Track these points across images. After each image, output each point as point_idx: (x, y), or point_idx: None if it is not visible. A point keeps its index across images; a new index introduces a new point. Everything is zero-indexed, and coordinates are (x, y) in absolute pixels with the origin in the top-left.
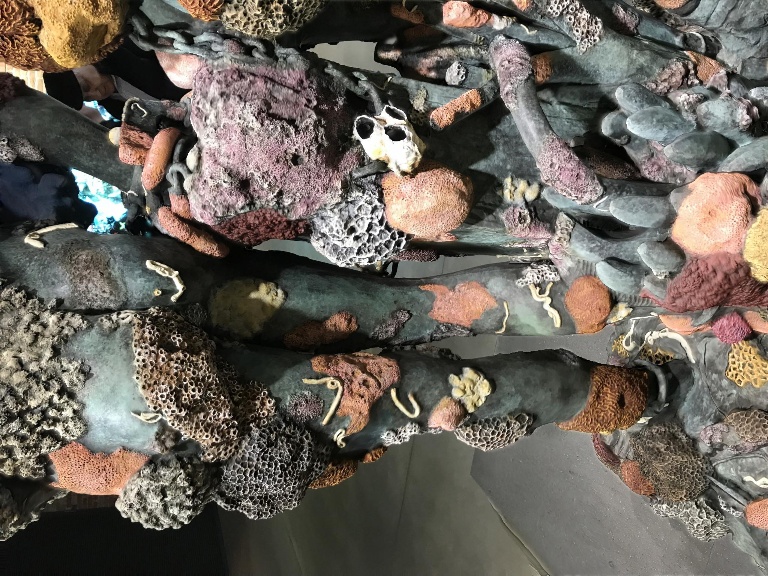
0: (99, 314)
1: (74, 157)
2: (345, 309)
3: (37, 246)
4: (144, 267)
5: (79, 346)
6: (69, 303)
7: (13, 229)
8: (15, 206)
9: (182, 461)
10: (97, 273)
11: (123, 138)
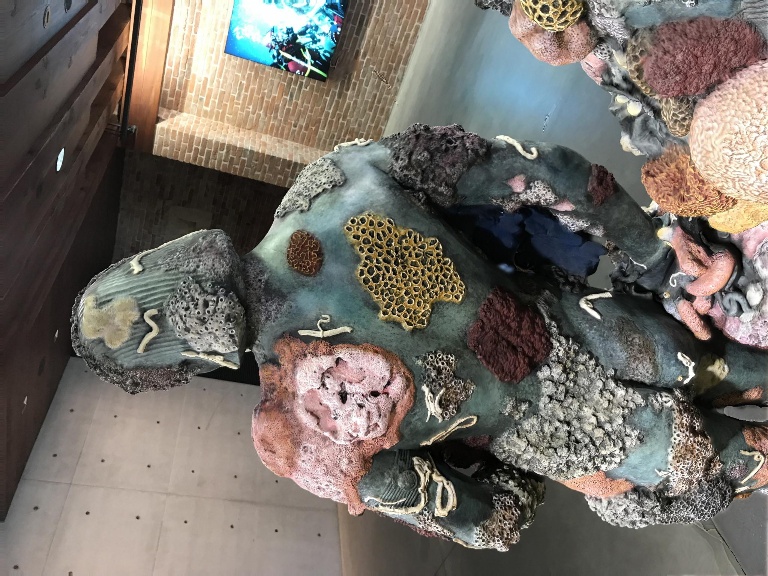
0: (640, 387)
1: (623, 239)
2: (760, 384)
3: (595, 316)
4: (676, 358)
5: (639, 419)
6: (620, 373)
7: (558, 282)
8: (542, 248)
9: (656, 495)
10: (648, 358)
11: (689, 252)
